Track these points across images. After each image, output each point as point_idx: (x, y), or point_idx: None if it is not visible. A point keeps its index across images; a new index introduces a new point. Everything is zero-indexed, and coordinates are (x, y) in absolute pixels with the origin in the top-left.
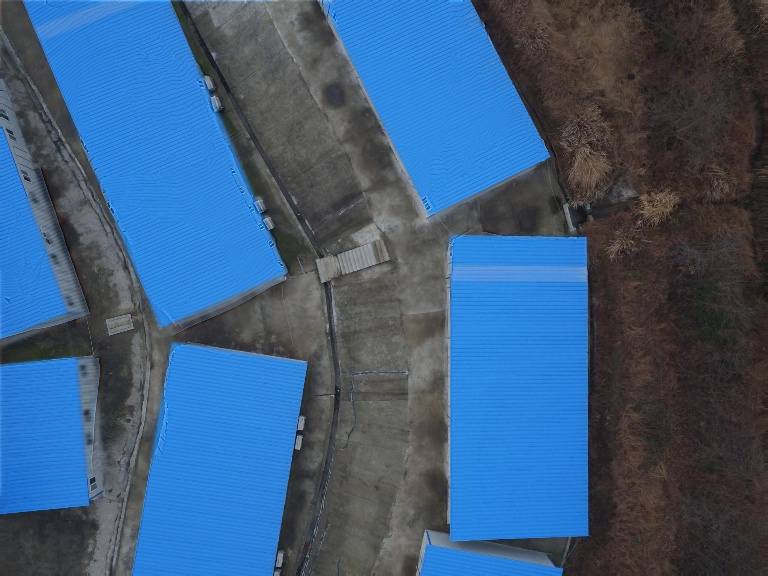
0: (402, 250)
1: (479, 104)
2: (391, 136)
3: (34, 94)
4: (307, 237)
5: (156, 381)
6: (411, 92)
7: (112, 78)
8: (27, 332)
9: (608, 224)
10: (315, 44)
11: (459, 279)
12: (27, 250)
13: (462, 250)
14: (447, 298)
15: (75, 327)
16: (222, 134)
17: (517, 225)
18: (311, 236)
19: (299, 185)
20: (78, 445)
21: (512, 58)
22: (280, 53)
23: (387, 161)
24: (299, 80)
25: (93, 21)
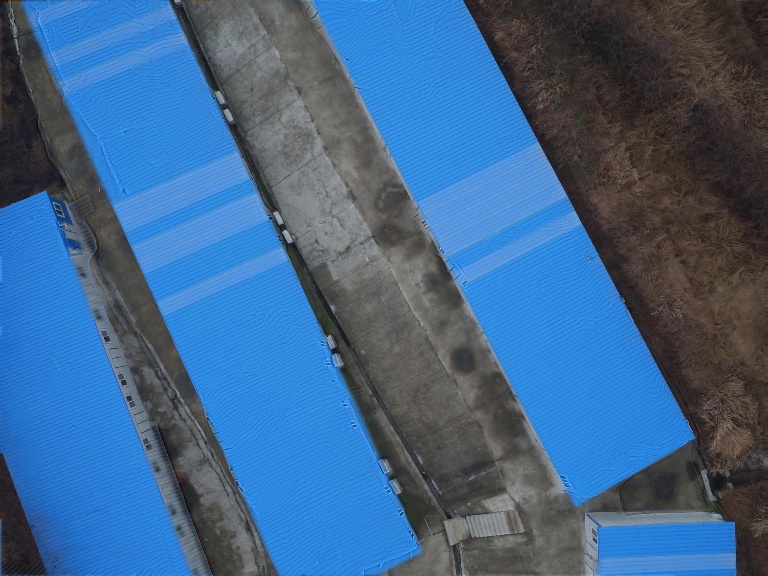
0: (537, 521)
1: (621, 385)
2: (523, 402)
3: (150, 353)
4: (434, 497)
5: None
6: (541, 354)
7: (238, 353)
8: None
9: (752, 499)
10: (442, 306)
11: (606, 572)
12: (145, 507)
13: (609, 542)
14: (586, 575)
15: None
16: (342, 387)
17: (654, 493)
18: (437, 495)
19: (425, 445)
20: None
21: (649, 325)
22: (405, 315)
23: (519, 429)
24: (426, 343)
25: (215, 292)
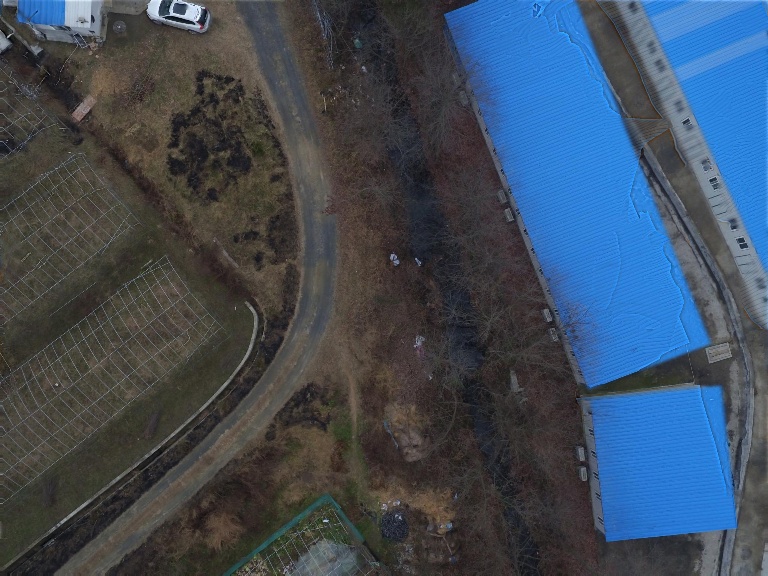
0: None
1: None
2: None
3: None
4: None
5: (760, 407)
6: None
7: (742, 119)
8: (655, 361)
9: None
10: None
11: None
12: (614, 281)
13: None
14: None
15: (676, 355)
16: None
17: None
18: None
19: None
20: (714, 469)
21: None
22: None
23: None
24: None
25: (718, 64)
